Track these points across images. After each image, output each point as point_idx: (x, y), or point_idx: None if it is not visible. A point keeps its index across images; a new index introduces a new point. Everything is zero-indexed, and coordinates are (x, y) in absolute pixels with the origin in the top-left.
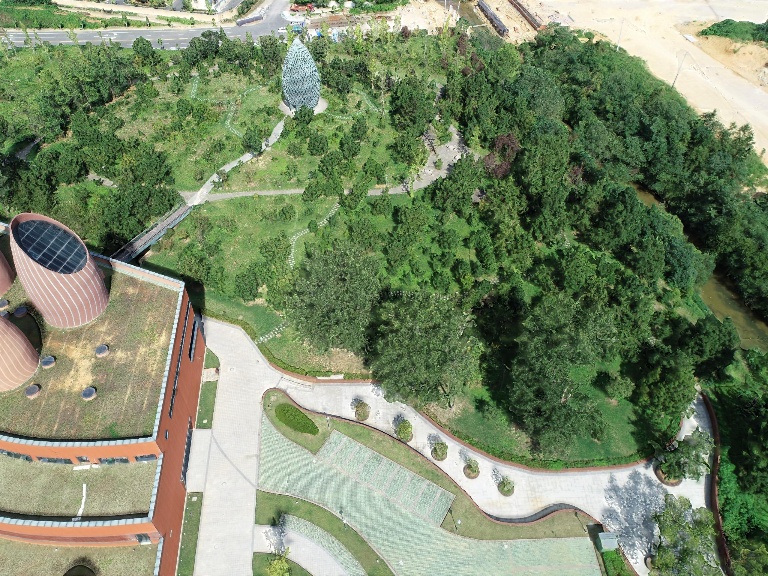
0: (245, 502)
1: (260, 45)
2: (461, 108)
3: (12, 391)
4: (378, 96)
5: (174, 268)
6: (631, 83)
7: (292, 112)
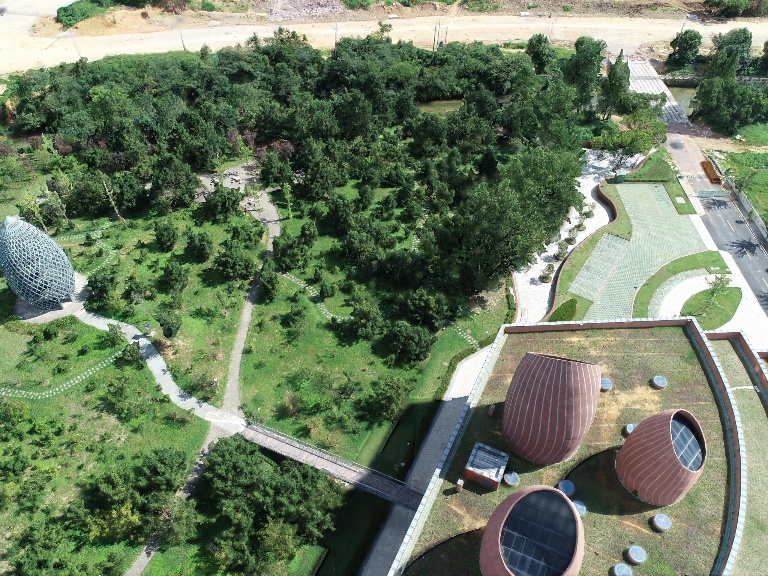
0: None
1: None
2: (159, 158)
3: None
4: (74, 224)
5: (395, 411)
6: (174, 61)
7: (93, 293)
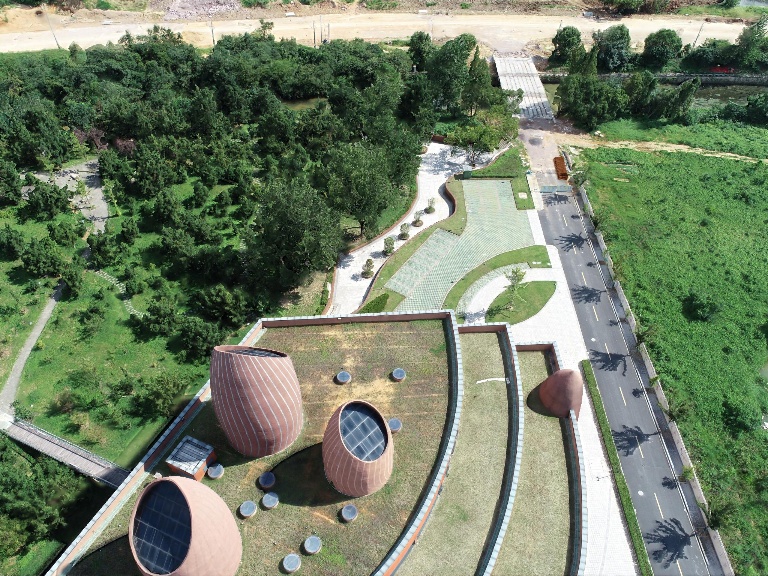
0: None
1: None
2: None
3: None
4: None
5: None
6: (42, 60)
7: None
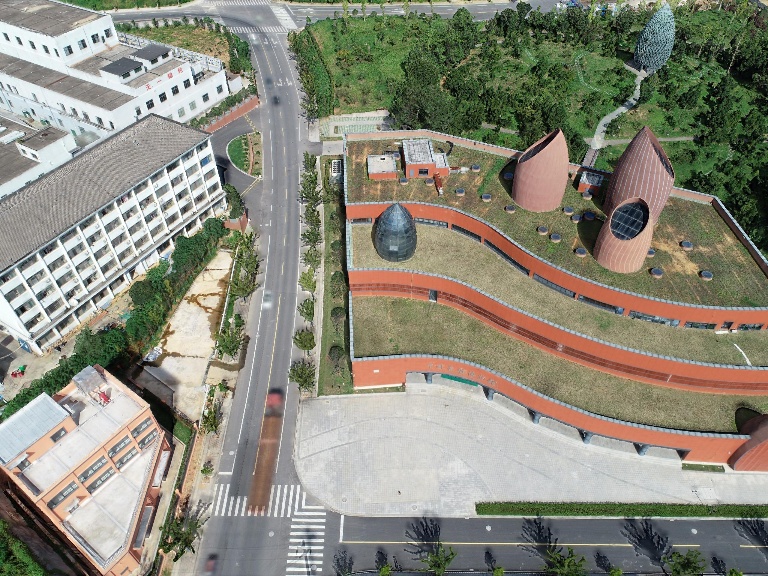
0: None
1: (564, 17)
2: None
3: (636, 273)
4: (710, 60)
5: None
6: None
7: (653, 71)
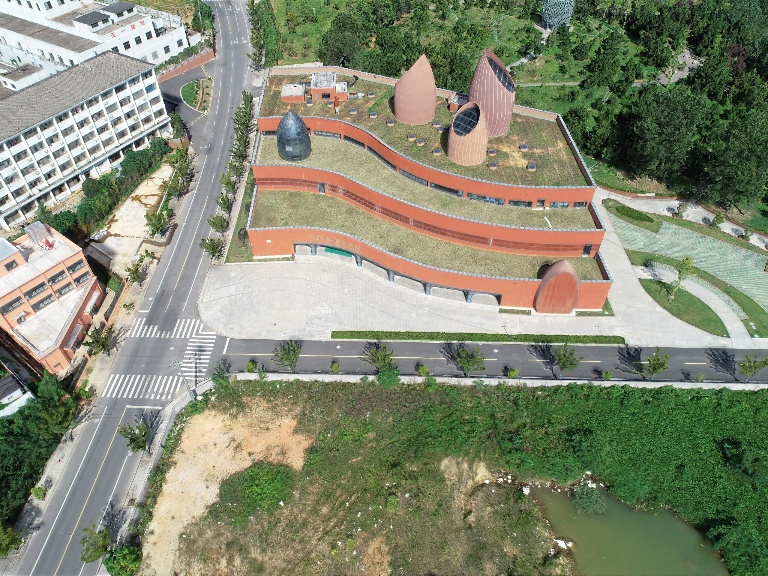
0: (619, 254)
1: None
2: (689, 28)
3: (477, 166)
4: None
5: None
6: None
7: (554, 28)
